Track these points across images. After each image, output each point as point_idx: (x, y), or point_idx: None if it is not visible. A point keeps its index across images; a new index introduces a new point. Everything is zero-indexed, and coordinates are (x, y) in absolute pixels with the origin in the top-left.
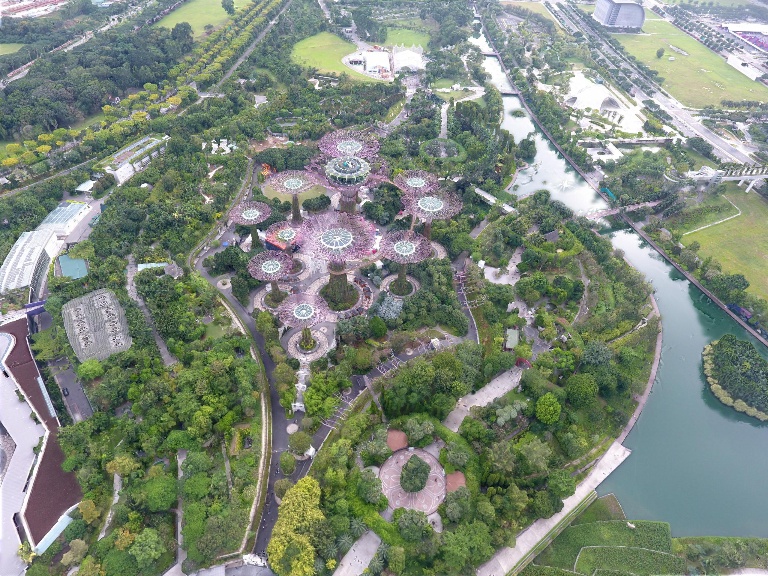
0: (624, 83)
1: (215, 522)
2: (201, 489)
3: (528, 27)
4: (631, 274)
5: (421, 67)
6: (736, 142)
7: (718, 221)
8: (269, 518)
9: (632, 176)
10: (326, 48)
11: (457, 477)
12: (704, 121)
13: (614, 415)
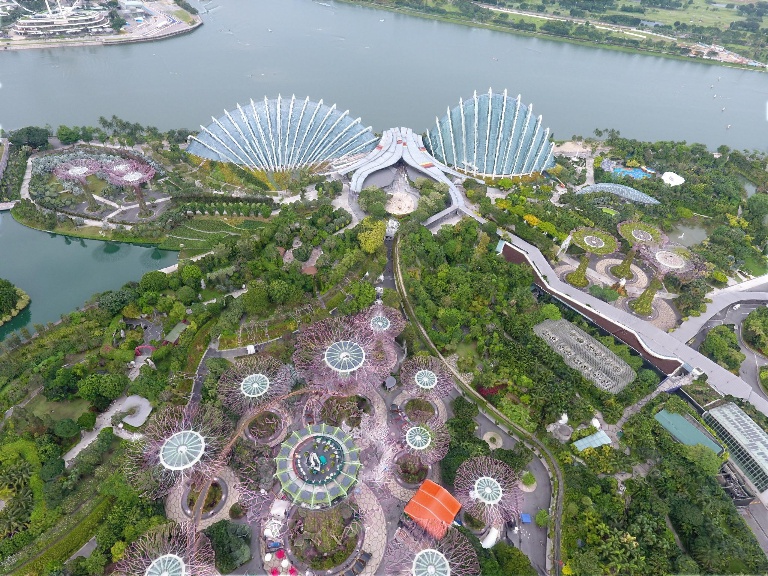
0: None
1: (414, 225)
2: (428, 242)
3: None
4: None
5: None
6: None
7: None
8: (389, 251)
9: None
10: None
11: None
12: None
13: (136, 287)
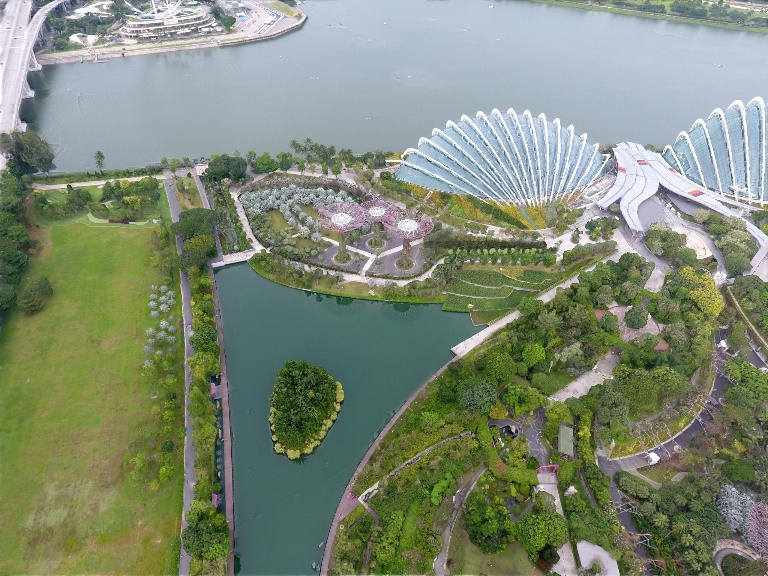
0: None
1: (760, 280)
2: None
3: None
4: None
5: None
6: None
7: None
8: None
9: None
10: None
11: None
12: None
13: None
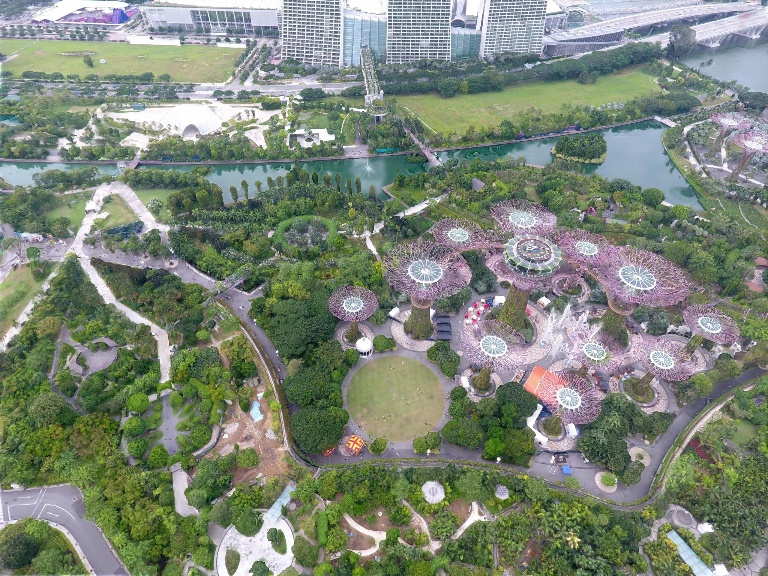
0: (165, 94)
1: None
2: None
3: None
4: None
5: None
6: (297, 81)
7: None
8: None
9: None
10: None
11: (757, 260)
12: (256, 83)
13: None
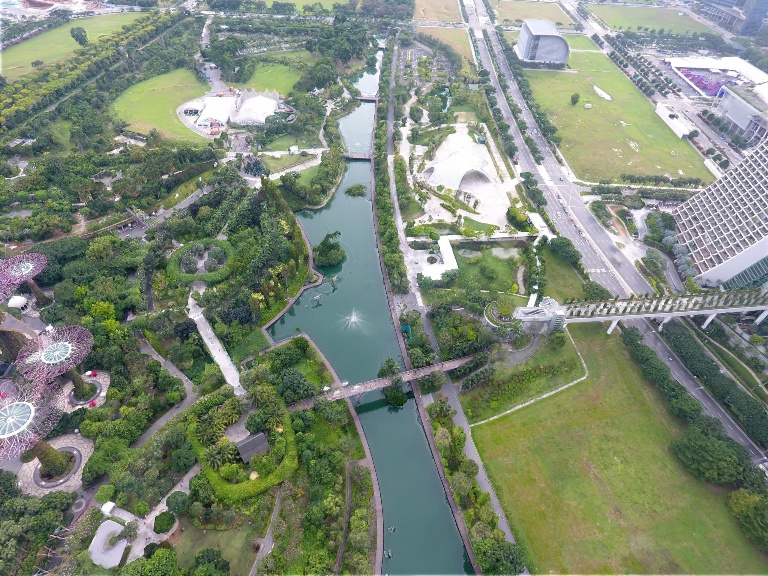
0: (507, 145)
1: None
2: None
3: (429, 63)
4: (351, 527)
5: (263, 120)
6: (625, 239)
7: (548, 392)
8: None
9: (443, 310)
10: (167, 91)
11: None
12: (593, 203)
13: None
